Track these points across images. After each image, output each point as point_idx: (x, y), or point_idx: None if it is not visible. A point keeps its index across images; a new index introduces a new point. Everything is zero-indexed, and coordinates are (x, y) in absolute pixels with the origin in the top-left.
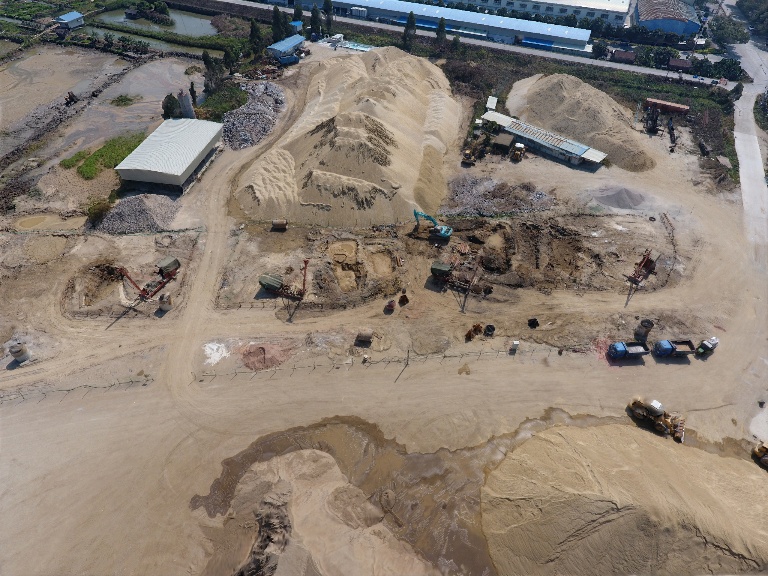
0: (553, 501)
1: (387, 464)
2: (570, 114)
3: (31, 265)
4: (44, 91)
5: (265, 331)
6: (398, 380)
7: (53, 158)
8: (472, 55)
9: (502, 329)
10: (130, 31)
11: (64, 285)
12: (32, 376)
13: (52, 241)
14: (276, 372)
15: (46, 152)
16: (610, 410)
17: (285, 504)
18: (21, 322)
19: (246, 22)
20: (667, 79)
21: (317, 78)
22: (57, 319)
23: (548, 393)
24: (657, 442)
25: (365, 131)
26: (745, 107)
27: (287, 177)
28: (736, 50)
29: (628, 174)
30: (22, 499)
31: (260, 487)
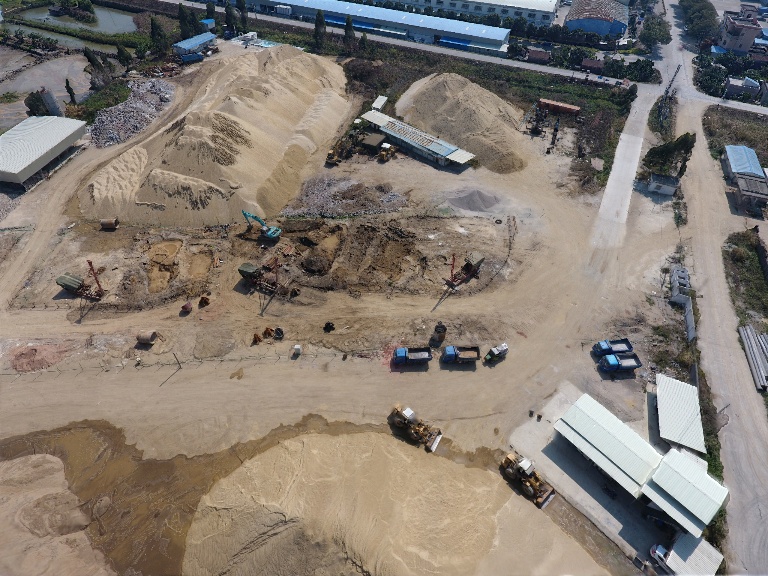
0: (243, 512)
1: (116, 470)
2: (449, 114)
3: None
4: None
5: (49, 332)
6: (164, 384)
7: None
8: (383, 54)
9: (294, 333)
10: (47, 28)
11: None
12: None
13: None
14: (42, 374)
15: None
16: (371, 417)
17: None
18: None
19: (169, 19)
20: (573, 79)
21: (212, 76)
22: None
23: (314, 399)
24: (399, 451)
25: (211, 130)
26: (643, 108)
27: (133, 176)
28: (661, 51)
29: (493, 176)
30: None
31: None
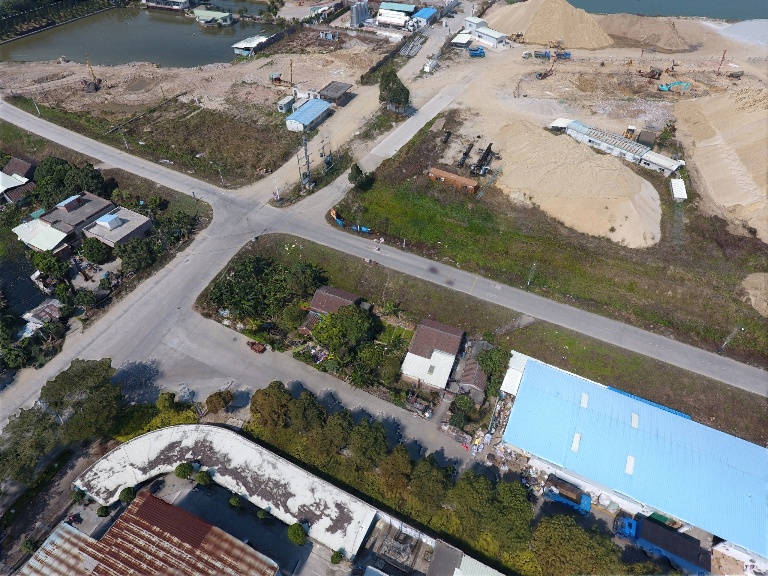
0: None
1: None
2: None
3: None
4: None
5: (721, 69)
6: None
7: None
8: None
9: None
10: None
11: None
12: None
13: None
14: None
15: None
16: None
17: None
18: None
19: None
20: None
21: None
22: None
23: None
24: None
25: None
26: (335, 189)
27: None
28: None
29: None
30: None
31: None
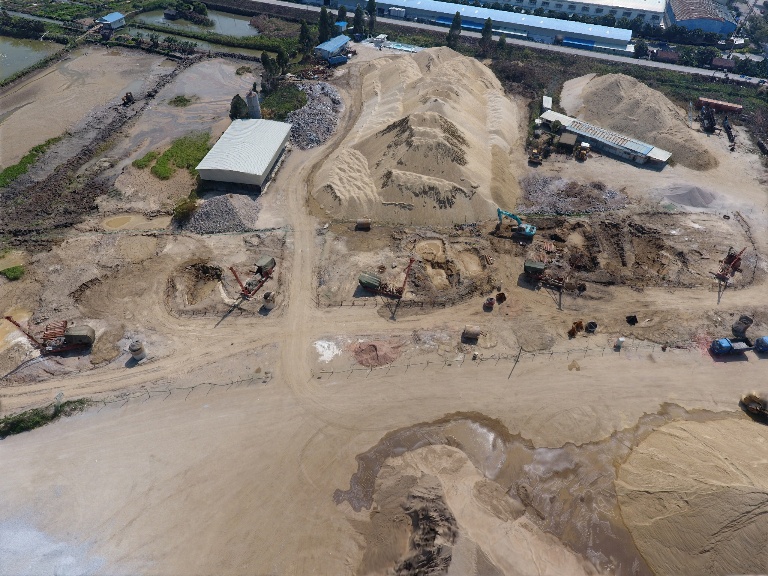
0: (700, 493)
1: (517, 459)
2: (629, 113)
3: (128, 264)
4: (98, 92)
5: (371, 329)
6: (511, 376)
7: (124, 158)
8: (516, 55)
9: (602, 326)
10: (172, 32)
11: (164, 284)
12: (152, 374)
13: (142, 241)
14: (390, 369)
15: (116, 152)
16: (724, 405)
17: (440, 497)
18: (130, 321)
19: (285, 22)
20: (714, 78)
21: (370, 78)
22: (164, 318)
23: (660, 388)
24: None
25: (441, 131)
26: None
27: (363, 177)
28: None
29: (694, 173)
30: (168, 494)
31: (403, 481)
